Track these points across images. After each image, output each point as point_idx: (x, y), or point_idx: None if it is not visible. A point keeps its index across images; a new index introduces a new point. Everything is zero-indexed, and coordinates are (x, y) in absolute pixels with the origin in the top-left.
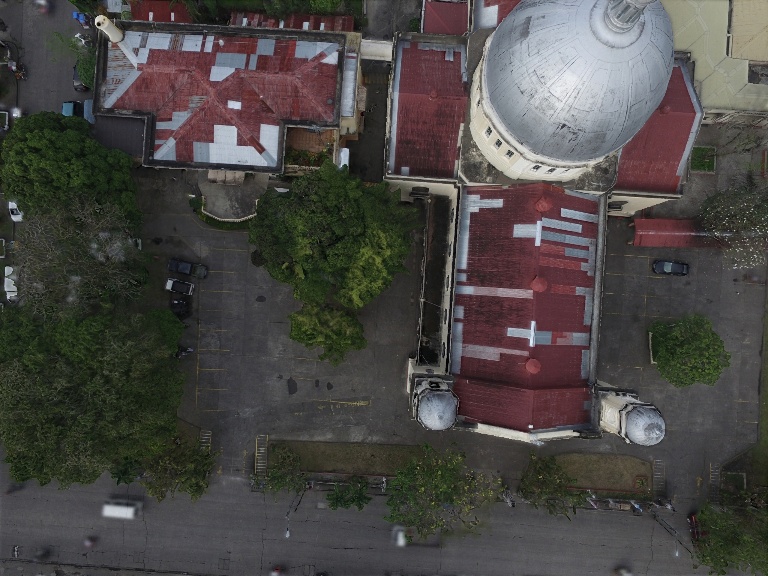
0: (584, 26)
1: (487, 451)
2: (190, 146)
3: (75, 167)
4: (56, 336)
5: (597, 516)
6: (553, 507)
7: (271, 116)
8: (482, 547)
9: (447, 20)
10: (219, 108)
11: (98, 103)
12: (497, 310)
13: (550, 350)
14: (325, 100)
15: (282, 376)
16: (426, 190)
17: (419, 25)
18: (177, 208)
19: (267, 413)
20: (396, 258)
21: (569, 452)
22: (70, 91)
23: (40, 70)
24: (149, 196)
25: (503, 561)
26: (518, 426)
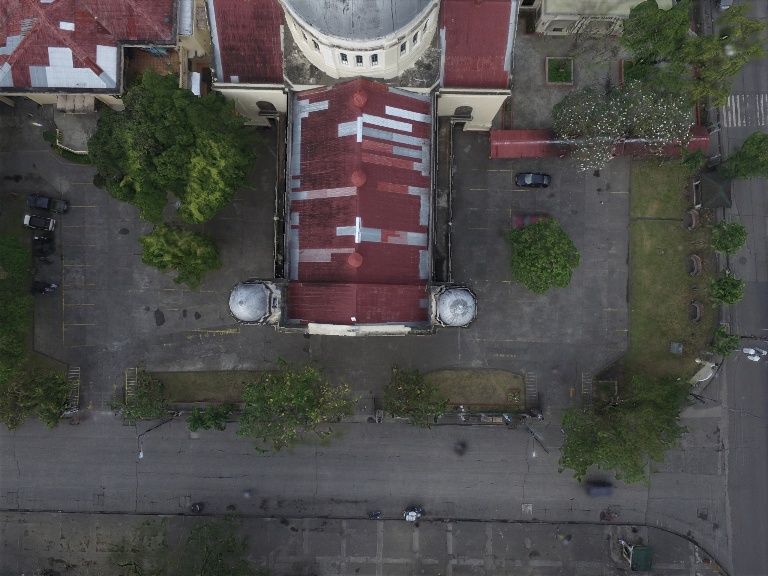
0: None
1: (359, 372)
2: (26, 71)
3: None
4: None
5: (472, 432)
6: (413, 417)
7: (108, 37)
8: (358, 469)
9: None
10: (51, 30)
11: None
12: (327, 211)
13: (380, 248)
14: (161, 19)
15: (149, 308)
16: (272, 107)
17: None
18: (35, 145)
19: (135, 346)
20: (231, 169)
21: (441, 369)
22: None
23: None
24: (6, 134)
25: (379, 481)
26: (344, 321)
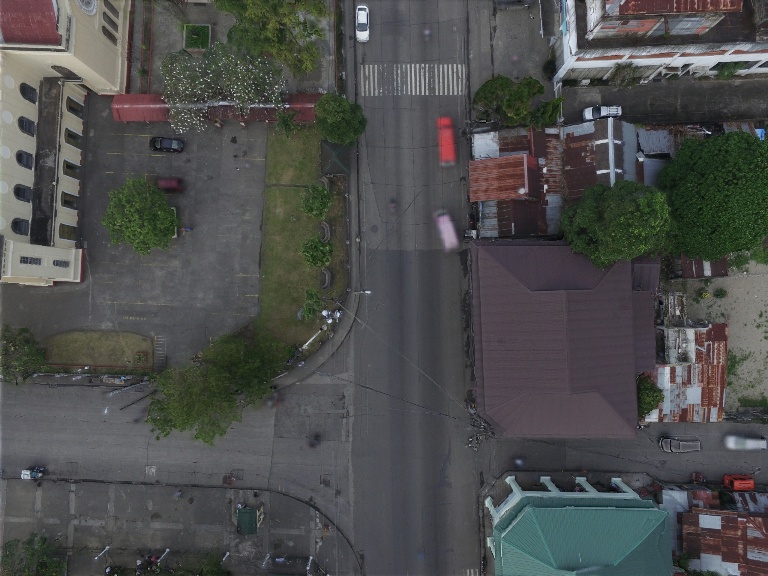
0: None
1: None
2: None
3: None
4: None
5: (99, 393)
6: None
7: None
8: None
9: None
10: None
11: None
12: None
13: None
14: None
15: None
16: None
17: None
18: None
19: None
20: None
21: (70, 330)
22: None
23: None
24: None
25: (4, 440)
26: None
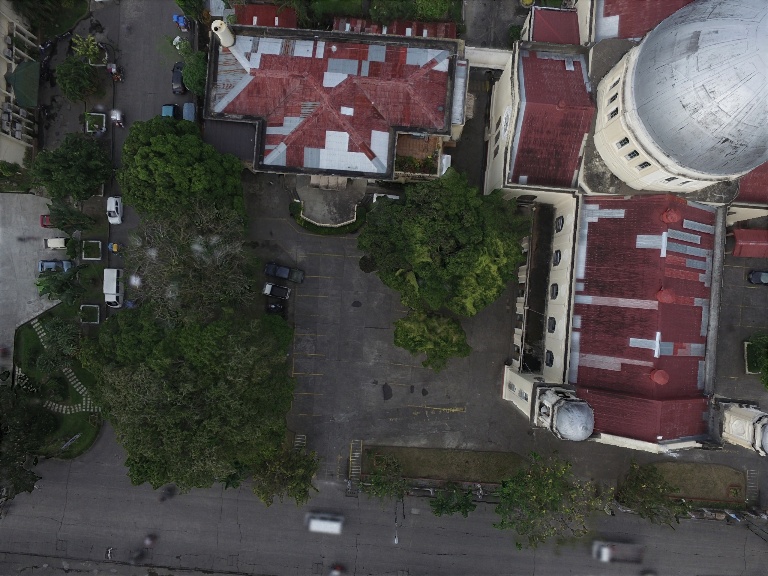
0: (766, 42)
1: (581, 459)
2: (301, 151)
3: (198, 172)
4: (180, 341)
5: (690, 525)
6: (656, 516)
7: (382, 122)
8: (575, 554)
9: (558, 29)
10: (332, 114)
11: (209, 107)
12: (618, 320)
13: (672, 361)
14: (436, 107)
15: (377, 381)
16: (532, 198)
17: (521, 33)
18: (273, 212)
19: (362, 418)
20: (512, 267)
21: (663, 461)
22: (167, 94)
23: (137, 72)
24: (246, 200)
25: (596, 569)
26: (644, 437)
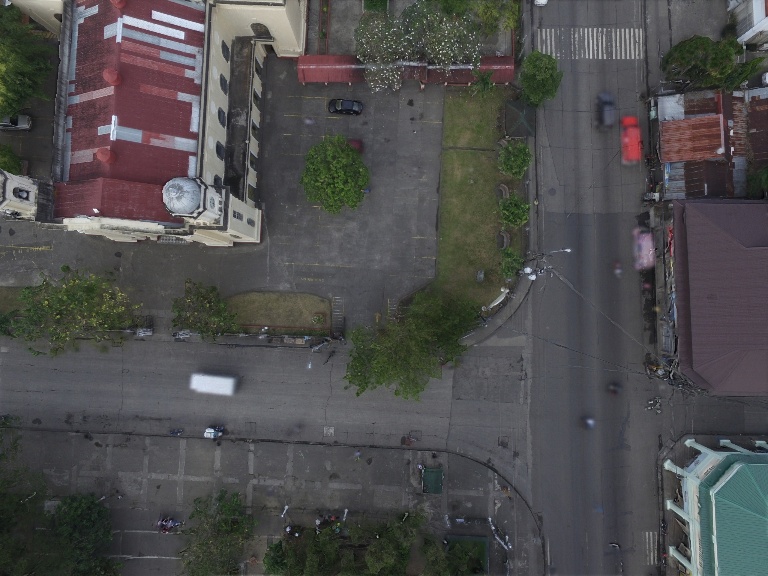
0: None
1: (168, 292)
2: None
3: None
4: None
5: (277, 354)
6: (200, 329)
7: None
8: (163, 386)
9: None
10: None
11: None
12: (92, 112)
13: (140, 148)
14: None
15: None
16: None
17: None
18: None
19: None
20: (11, 73)
21: (249, 291)
22: None
23: None
24: None
25: (184, 400)
26: (92, 215)
